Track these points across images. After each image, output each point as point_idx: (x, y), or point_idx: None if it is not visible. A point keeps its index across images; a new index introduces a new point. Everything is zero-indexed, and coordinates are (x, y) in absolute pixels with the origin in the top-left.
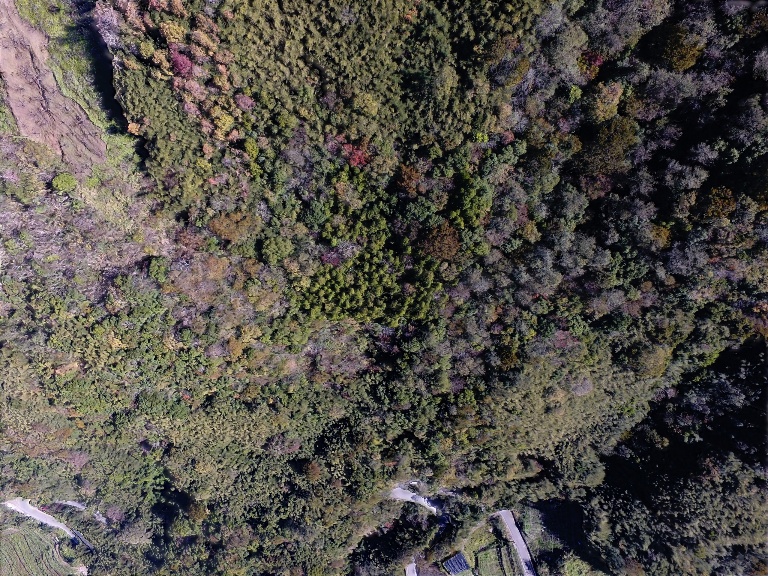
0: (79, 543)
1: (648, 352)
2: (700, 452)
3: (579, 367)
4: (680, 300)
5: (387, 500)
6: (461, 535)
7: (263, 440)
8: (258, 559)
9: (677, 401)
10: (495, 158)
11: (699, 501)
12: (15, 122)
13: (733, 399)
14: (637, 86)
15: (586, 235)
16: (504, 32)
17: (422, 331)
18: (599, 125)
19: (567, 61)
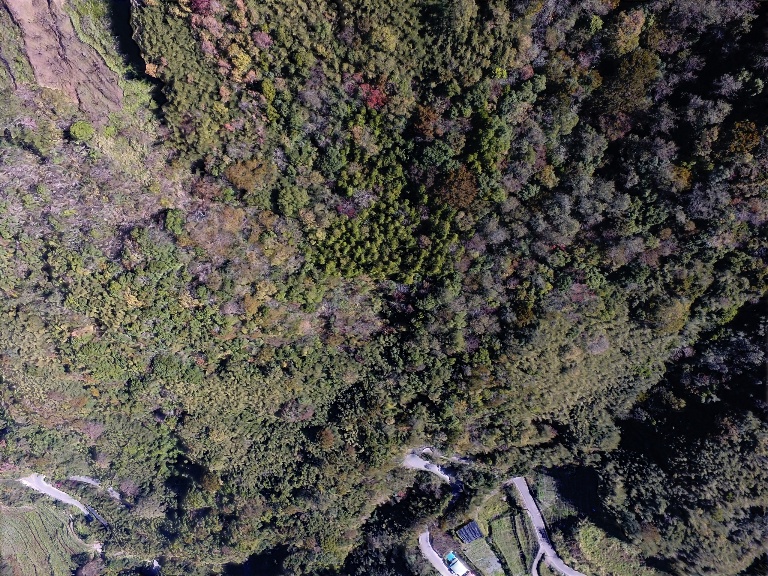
0: (93, 520)
1: (666, 305)
2: (718, 412)
3: (595, 324)
4: (699, 249)
5: (400, 468)
6: (475, 503)
7: (277, 406)
8: (271, 530)
9: (694, 361)
10: (514, 95)
11: (717, 462)
12: (32, 72)
13: (752, 357)
14: (659, 15)
15: (605, 180)
16: None
17: (437, 287)
18: (620, 58)
19: None
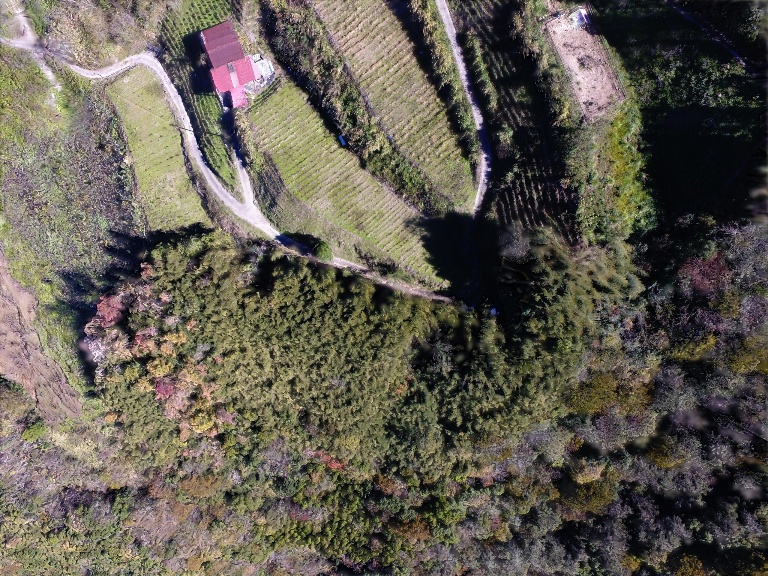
0: None
1: None
2: None
3: None
4: None
5: None
6: None
7: None
8: None
9: None
10: (472, 492)
11: None
12: None
13: None
14: None
15: (557, 540)
16: (491, 430)
17: (386, 571)
18: (579, 483)
19: (552, 446)
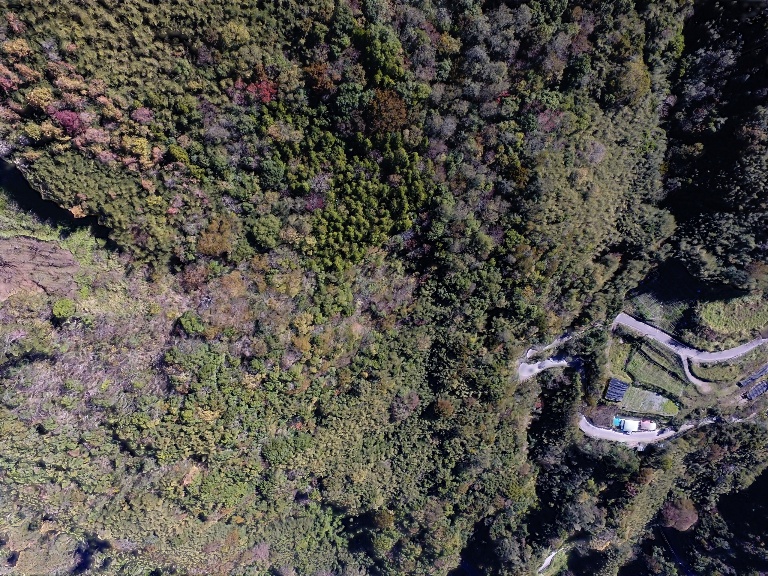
0: None
1: (624, 74)
2: (733, 129)
3: (580, 137)
4: (614, 4)
5: (521, 384)
6: (601, 363)
7: (386, 414)
8: (461, 518)
9: (681, 105)
10: None
11: (765, 168)
12: None
13: (724, 61)
14: None
15: (495, 9)
16: None
17: (434, 210)
18: None
19: None
